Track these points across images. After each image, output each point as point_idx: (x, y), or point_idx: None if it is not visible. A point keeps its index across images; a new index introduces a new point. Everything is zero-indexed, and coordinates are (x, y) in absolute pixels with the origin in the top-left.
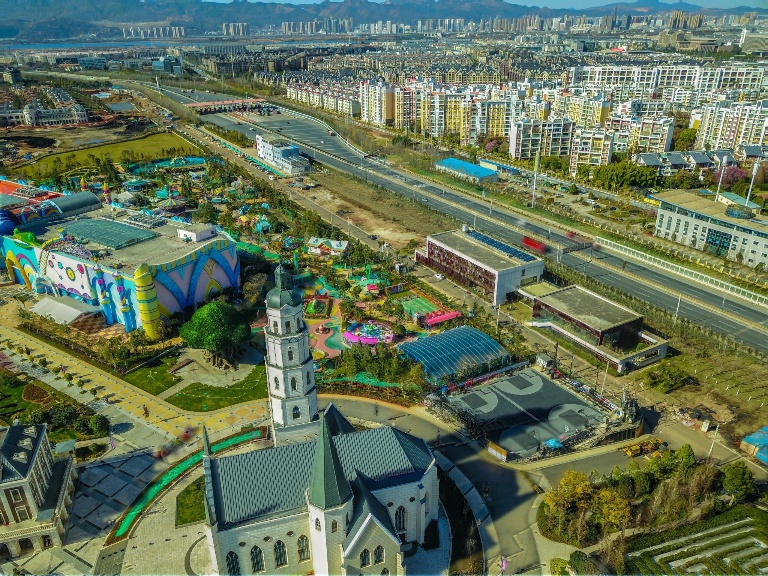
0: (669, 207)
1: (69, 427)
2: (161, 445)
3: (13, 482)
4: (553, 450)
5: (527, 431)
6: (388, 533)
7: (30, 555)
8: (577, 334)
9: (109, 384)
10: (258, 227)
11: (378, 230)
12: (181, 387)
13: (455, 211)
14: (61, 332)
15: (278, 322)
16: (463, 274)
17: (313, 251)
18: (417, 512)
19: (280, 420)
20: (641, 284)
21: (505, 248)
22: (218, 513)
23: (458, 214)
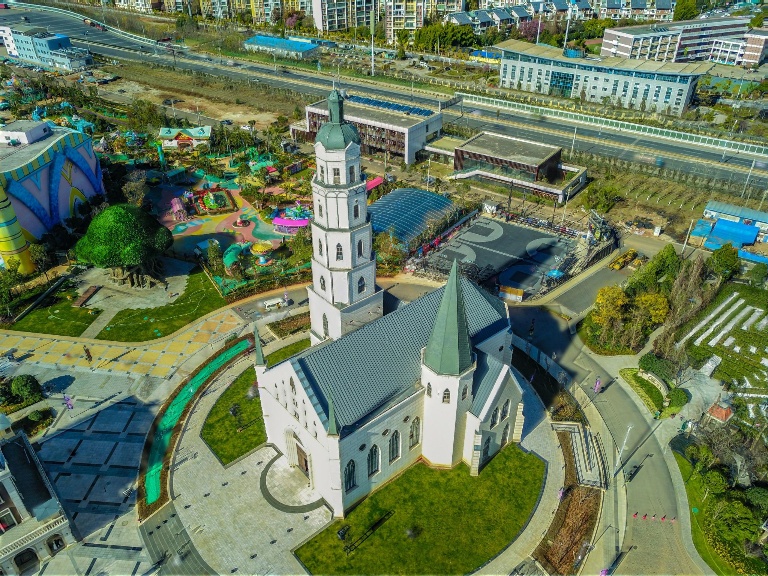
0: (512, 56)
1: None
2: (130, 388)
3: None
4: (559, 279)
5: (520, 270)
6: (517, 383)
7: (37, 569)
8: (510, 175)
9: None
10: None
11: (227, 115)
12: (107, 319)
13: (297, 87)
14: None
15: (341, 168)
16: None
17: (168, 145)
18: (504, 361)
19: (344, 298)
20: (519, 129)
21: (396, 107)
22: None
23: (302, 90)
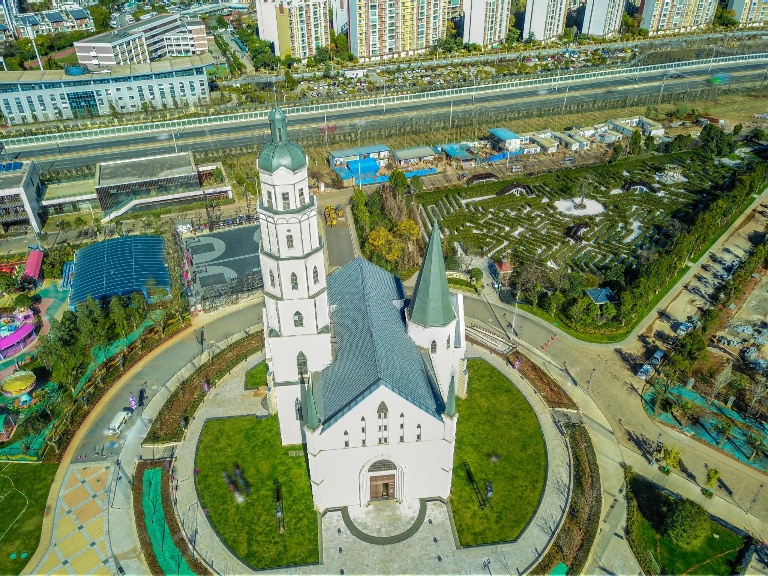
0: (8, 88)
1: None
2: None
3: None
4: None
5: None
6: None
7: None
8: (173, 192)
9: None
10: None
11: None
12: None
13: None
14: None
15: (304, 187)
16: None
17: None
18: None
19: (325, 321)
20: (95, 156)
21: None
22: None
23: None
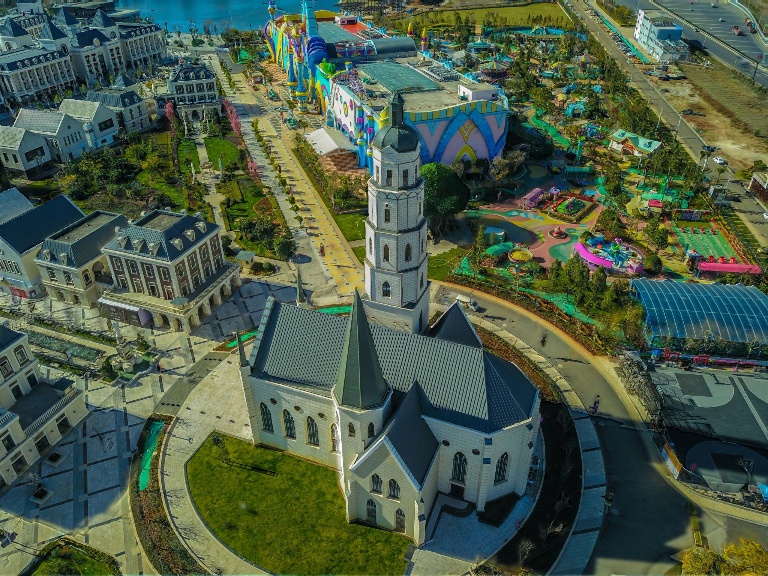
0: None
1: None
2: (318, 286)
3: (161, 261)
4: (765, 502)
5: (746, 458)
6: (404, 471)
7: (166, 331)
8: None
9: (320, 218)
10: (569, 108)
11: (723, 142)
12: None
13: None
14: (320, 162)
15: (379, 168)
16: None
17: (614, 147)
18: (480, 470)
19: (369, 292)
20: None
21: None
22: (260, 358)
23: None
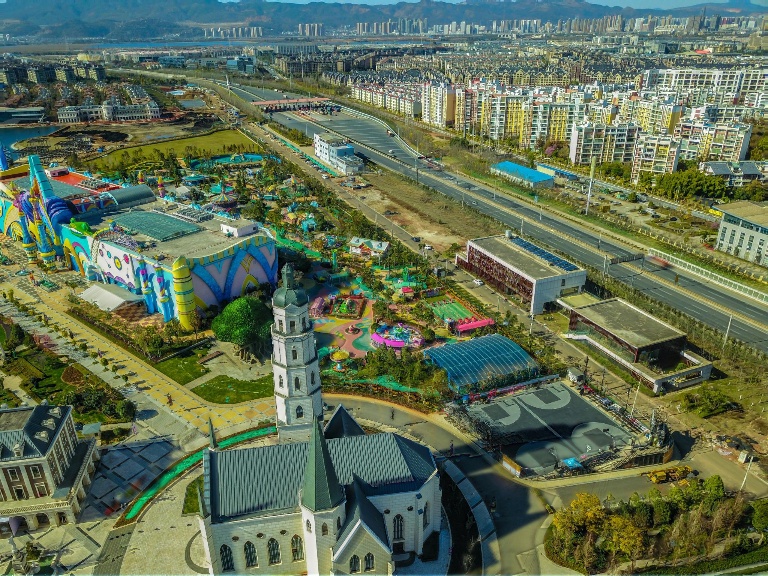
0: (733, 220)
1: (99, 410)
2: (181, 434)
3: (33, 459)
4: (571, 469)
5: (547, 447)
6: (378, 541)
7: (46, 530)
8: (613, 349)
9: (141, 371)
10: (304, 225)
11: (423, 232)
12: (208, 378)
13: (504, 216)
14: (105, 318)
15: (283, 321)
16: (501, 281)
17: (354, 251)
18: (415, 522)
19: (284, 418)
20: (693, 300)
21: (547, 256)
22: (213, 506)
23: (507, 219)
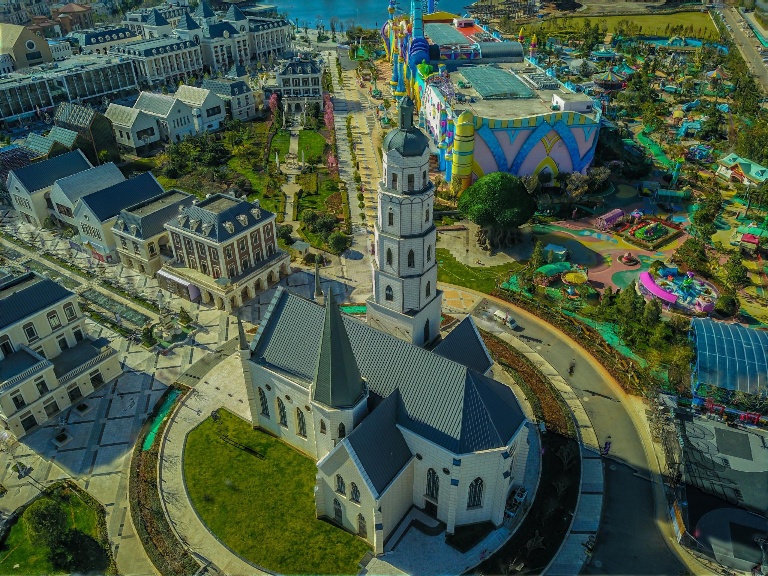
0: None
1: None
2: (362, 284)
3: (211, 242)
4: None
5: None
6: (362, 476)
7: (210, 307)
8: None
9: None
10: (683, 127)
11: None
12: None
13: None
14: None
15: (386, 170)
16: None
17: (723, 172)
18: None
19: None
20: None
21: None
22: (262, 344)
23: None
